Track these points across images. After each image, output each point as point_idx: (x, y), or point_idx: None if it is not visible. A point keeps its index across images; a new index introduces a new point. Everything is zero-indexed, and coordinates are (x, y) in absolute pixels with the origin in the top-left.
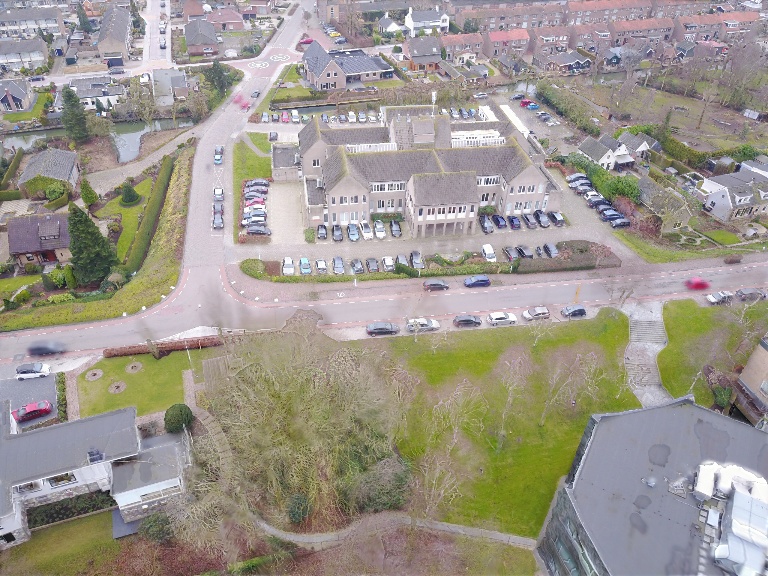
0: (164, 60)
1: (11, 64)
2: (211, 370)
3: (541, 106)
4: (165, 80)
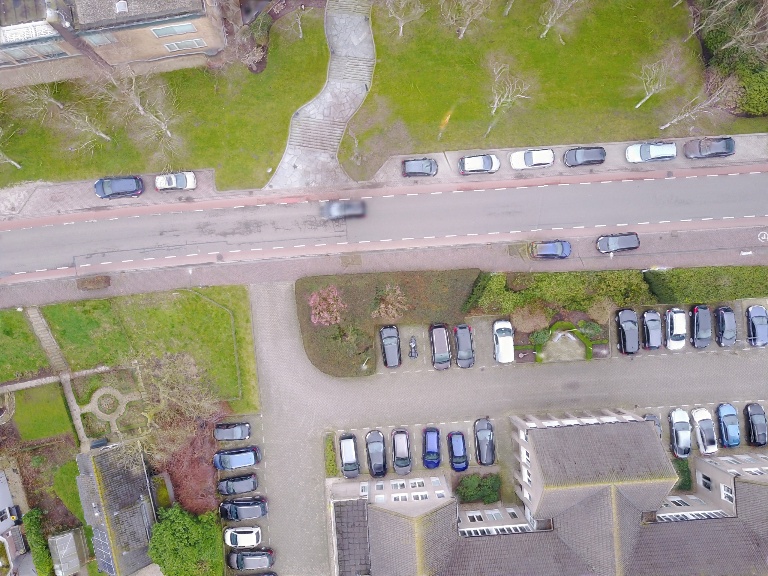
0: None
1: None
2: None
3: None
4: None
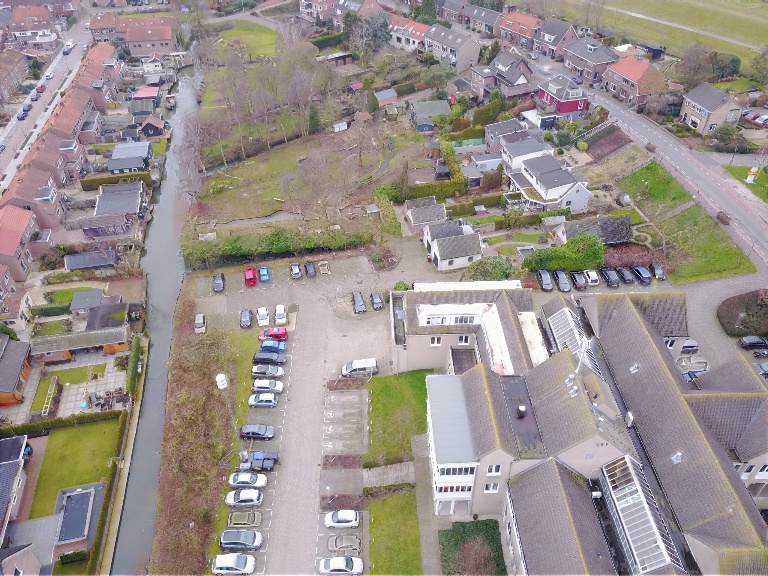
0: None
1: None
2: None
3: (259, 266)
4: None
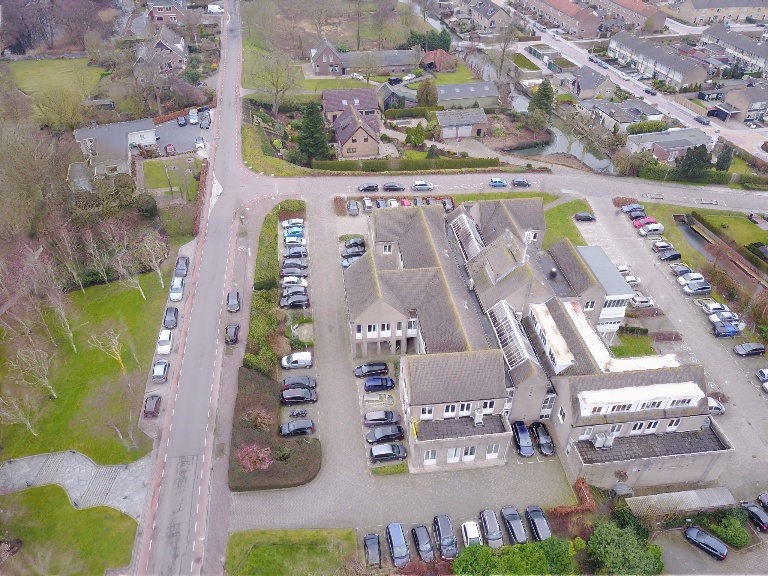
0: (767, 140)
1: (661, 74)
2: (174, 196)
3: None
4: (675, 137)
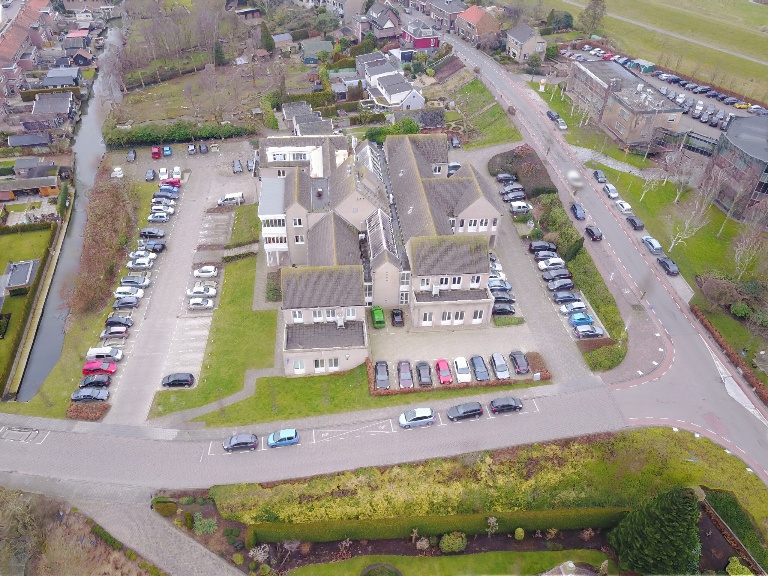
0: None
1: None
2: None
3: None
4: None
